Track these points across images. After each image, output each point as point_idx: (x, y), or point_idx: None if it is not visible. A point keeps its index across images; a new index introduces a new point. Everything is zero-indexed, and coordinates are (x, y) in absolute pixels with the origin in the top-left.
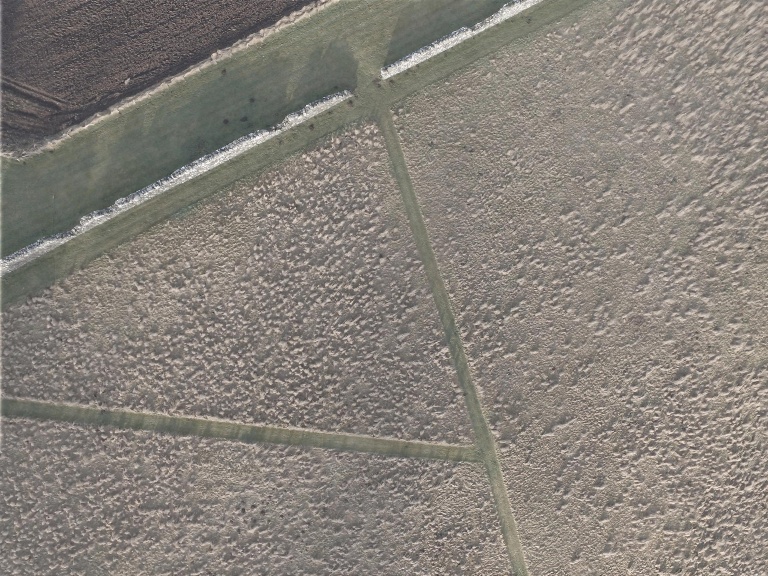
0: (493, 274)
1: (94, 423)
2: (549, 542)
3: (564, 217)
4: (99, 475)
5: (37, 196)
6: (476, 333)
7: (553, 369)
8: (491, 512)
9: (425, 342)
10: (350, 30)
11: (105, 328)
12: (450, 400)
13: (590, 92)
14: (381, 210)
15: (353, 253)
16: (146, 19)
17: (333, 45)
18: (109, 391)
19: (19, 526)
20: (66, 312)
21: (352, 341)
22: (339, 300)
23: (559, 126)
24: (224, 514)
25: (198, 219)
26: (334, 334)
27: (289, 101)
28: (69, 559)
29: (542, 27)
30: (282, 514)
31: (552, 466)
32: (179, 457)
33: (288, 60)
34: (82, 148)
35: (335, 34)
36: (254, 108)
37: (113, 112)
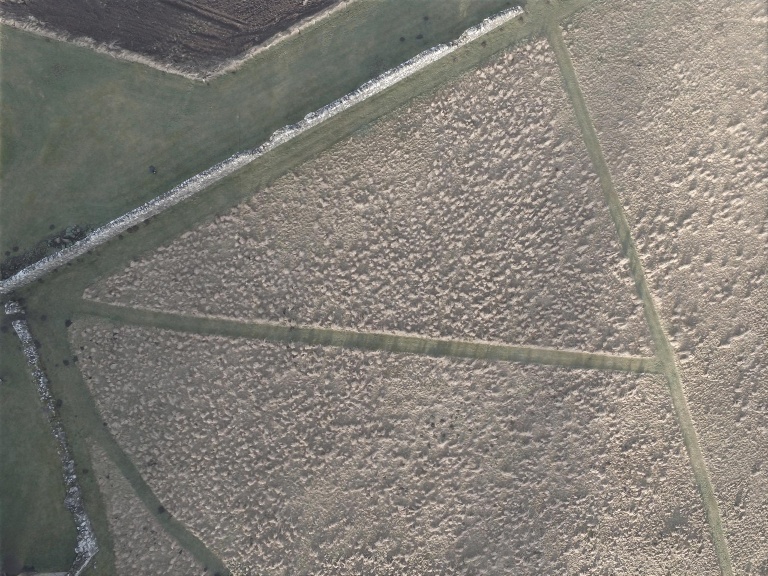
0: (665, 186)
1: (284, 340)
2: (730, 454)
3: (732, 129)
4: (291, 391)
5: (222, 116)
6: (652, 245)
7: (726, 281)
8: (673, 424)
9: (604, 254)
10: None
11: (292, 245)
12: (630, 312)
13: (750, 6)
14: (555, 124)
15: (530, 167)
16: None
17: None
18: (297, 308)
19: (216, 443)
20: (253, 230)
21: (534, 253)
22: (519, 213)
23: (723, 39)
24: (414, 429)
25: (379, 136)
26: (515, 247)
27: (463, 18)
28: (266, 475)
29: None
30: (470, 428)
31: (729, 378)
32: (368, 372)
33: None
34: (264, 68)
35: None
36: (428, 26)
37: (294, 32)
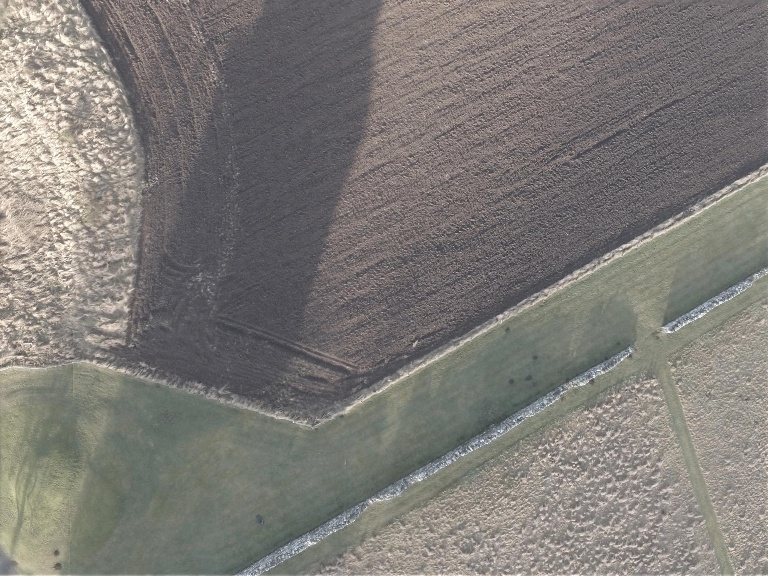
0: None
1: None
2: None
3: None
4: None
5: (329, 462)
6: None
7: None
8: None
9: None
10: (630, 284)
11: None
12: None
13: None
14: (662, 465)
15: (636, 510)
16: (433, 280)
17: (613, 299)
18: None
19: None
20: None
21: None
22: (624, 560)
23: None
24: None
25: (486, 482)
26: None
27: (572, 358)
28: None
29: None
30: None
31: None
32: None
33: (569, 315)
34: (372, 412)
35: (615, 288)
36: (537, 366)
37: (403, 376)
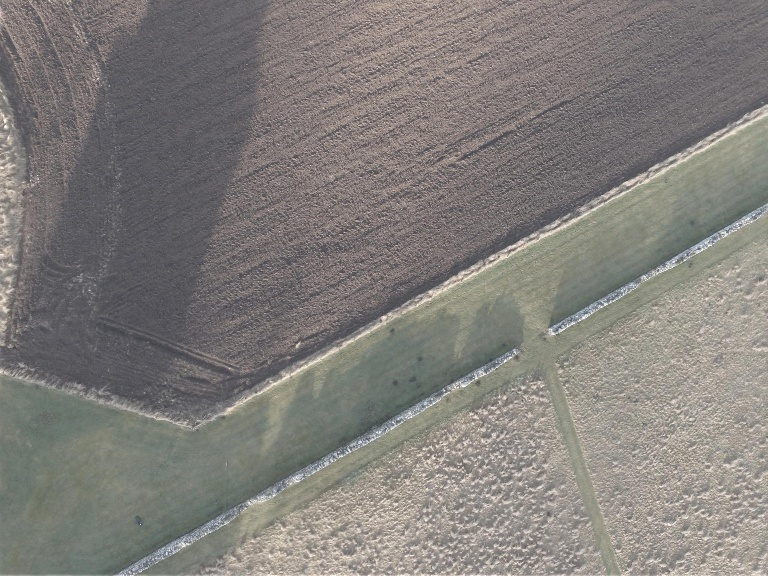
0: (658, 526)
1: None
2: None
3: (729, 465)
4: None
5: (210, 464)
6: None
7: None
8: None
9: None
10: (516, 285)
11: None
12: None
13: (751, 335)
14: (548, 466)
15: (521, 512)
16: (316, 282)
17: (499, 301)
18: None
19: None
20: None
21: None
22: (508, 562)
23: (722, 372)
24: None
25: (369, 483)
26: None
27: (457, 360)
28: None
29: (703, 271)
30: None
31: None
32: None
33: (455, 317)
34: (254, 413)
35: (501, 290)
36: (422, 367)
37: (285, 378)
